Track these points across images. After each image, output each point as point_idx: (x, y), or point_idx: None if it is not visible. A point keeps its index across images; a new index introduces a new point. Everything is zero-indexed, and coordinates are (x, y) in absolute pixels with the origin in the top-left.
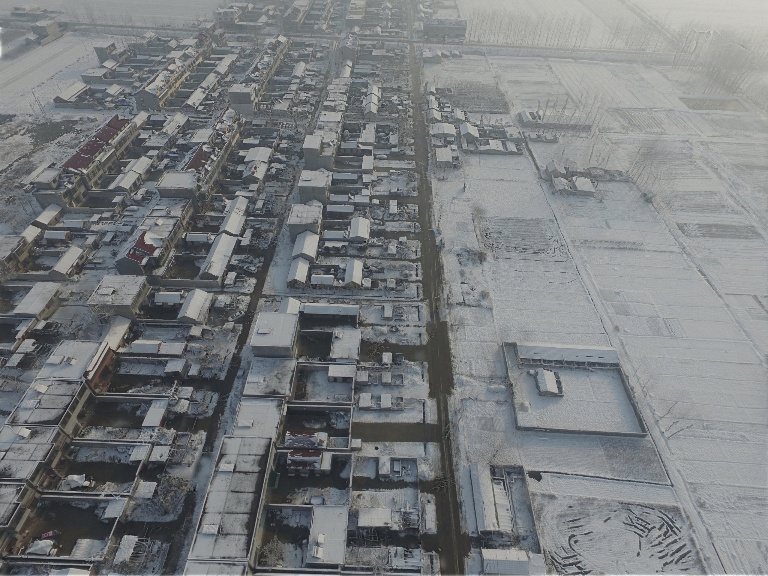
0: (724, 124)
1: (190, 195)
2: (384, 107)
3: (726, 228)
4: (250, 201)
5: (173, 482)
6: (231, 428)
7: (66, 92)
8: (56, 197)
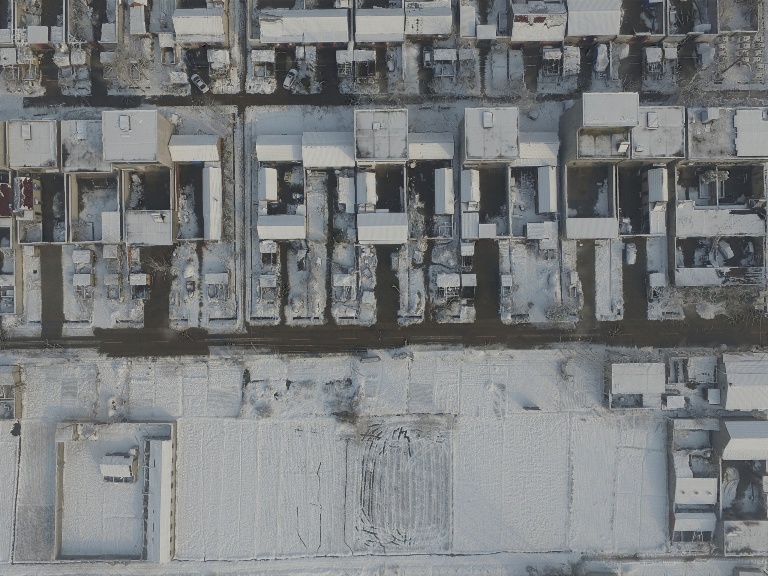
0: None
1: None
2: None
3: None
4: None
5: None
6: None
7: None
8: None
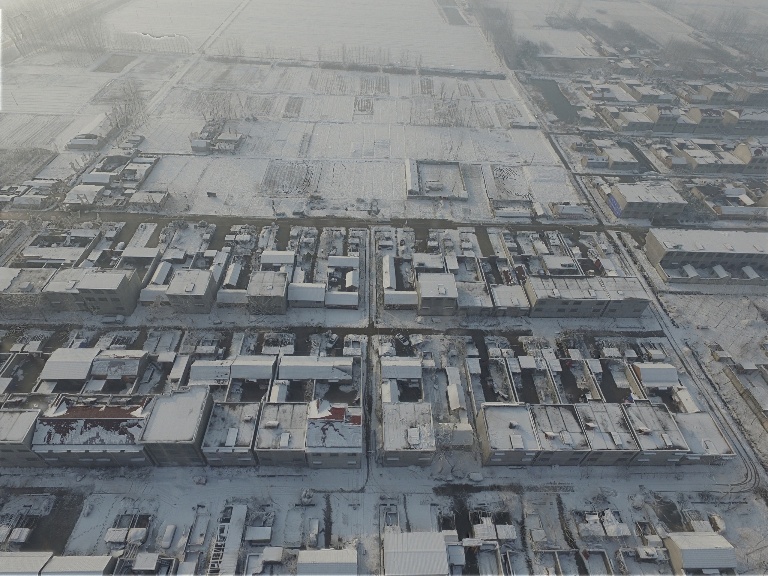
0: (154, 69)
1: (209, 401)
2: None
3: (291, 104)
4: (190, 365)
5: (570, 329)
6: None
7: None
8: None
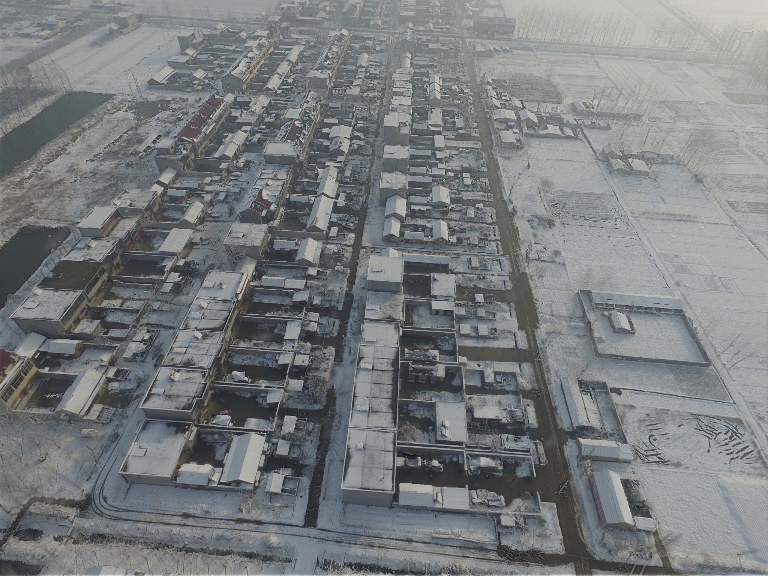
0: (767, 117)
1: (292, 162)
2: (446, 94)
3: None
4: (338, 171)
5: (321, 378)
6: (359, 343)
7: (158, 75)
8: (174, 161)
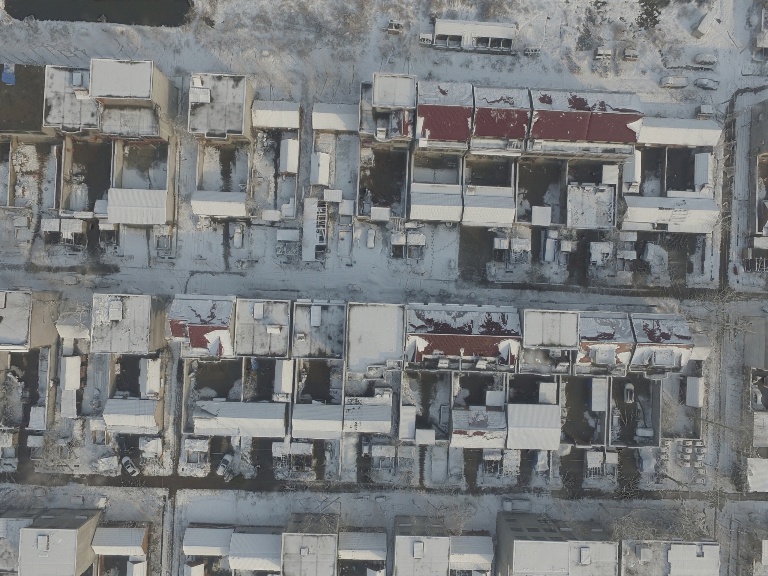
0: None
1: None
2: None
3: None
4: None
5: None
6: None
7: None
8: None
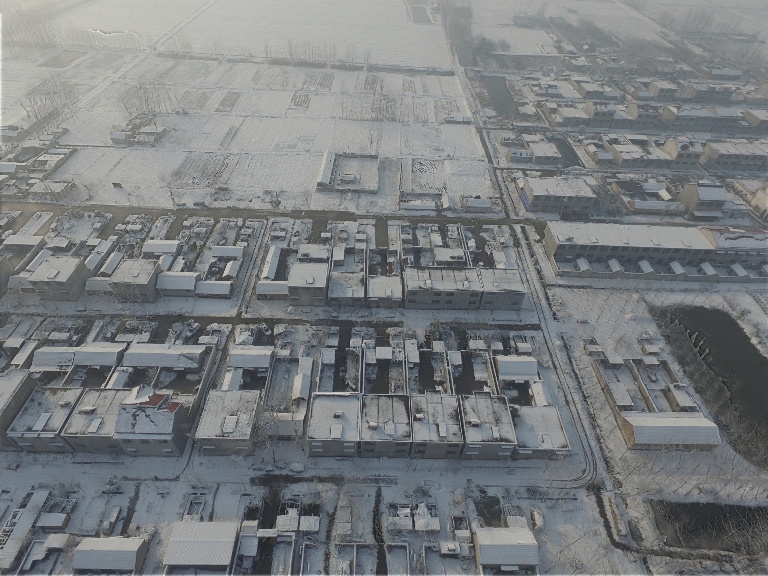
0: (100, 64)
1: (29, 385)
2: None
3: (227, 99)
4: None
5: (436, 321)
6: None
7: None
8: None
